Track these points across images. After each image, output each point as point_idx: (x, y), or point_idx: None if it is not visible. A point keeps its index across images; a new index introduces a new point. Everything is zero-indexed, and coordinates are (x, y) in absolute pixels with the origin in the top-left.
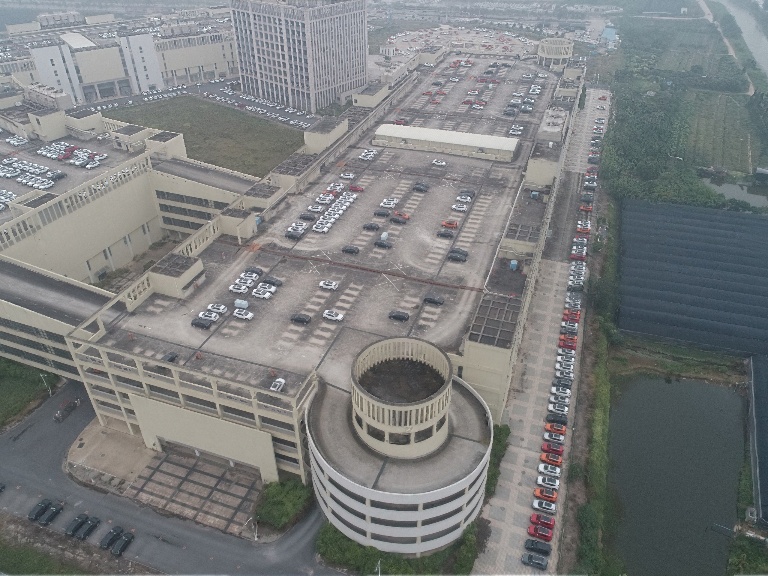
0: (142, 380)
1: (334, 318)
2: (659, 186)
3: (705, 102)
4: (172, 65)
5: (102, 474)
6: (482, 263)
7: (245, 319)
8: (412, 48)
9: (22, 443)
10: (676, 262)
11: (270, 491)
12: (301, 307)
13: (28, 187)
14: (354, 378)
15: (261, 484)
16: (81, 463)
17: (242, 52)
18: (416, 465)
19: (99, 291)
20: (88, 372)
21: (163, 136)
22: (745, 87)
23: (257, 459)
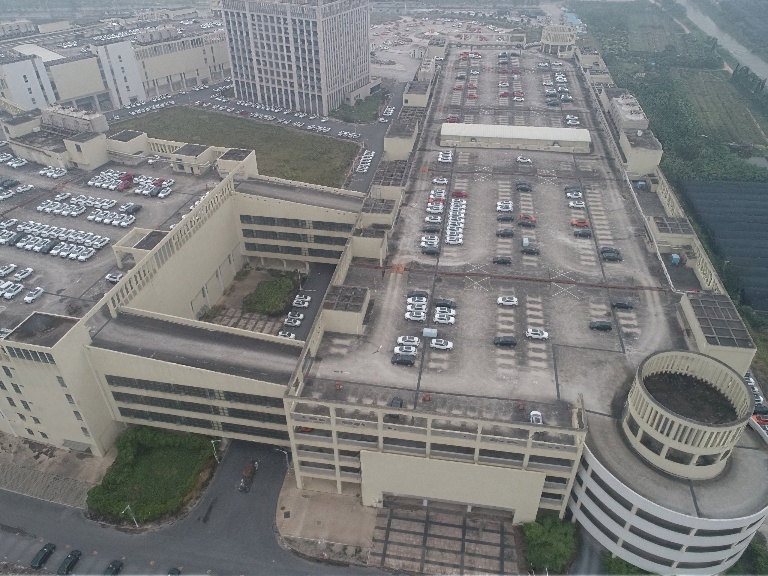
0: (380, 434)
1: (540, 336)
2: (703, 165)
3: (691, 80)
4: (153, 74)
5: (330, 544)
6: (639, 260)
7: (446, 349)
8: (388, 42)
9: (216, 523)
10: (765, 238)
11: (533, 533)
12: (494, 328)
13: (105, 225)
14: (657, 403)
15: (512, 526)
16: (299, 536)
17: (236, 56)
18: (720, 484)
19: (268, 337)
20: (298, 432)
21: (235, 154)
22: (721, 63)
23: (516, 501)
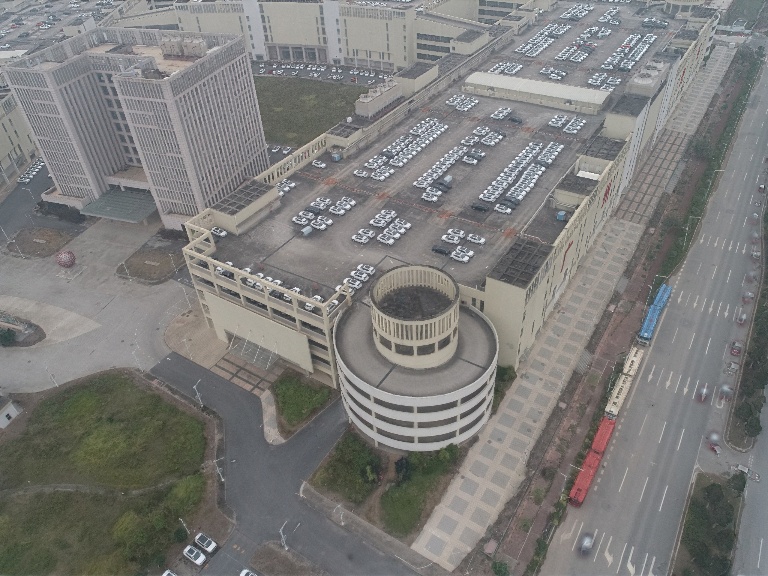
0: None
1: None
2: None
3: None
4: None
5: None
6: None
7: None
8: None
9: None
10: None
11: None
12: None
13: None
14: None
15: None
16: None
17: None
18: None
19: None
20: None
21: (184, 1)
22: None
23: None
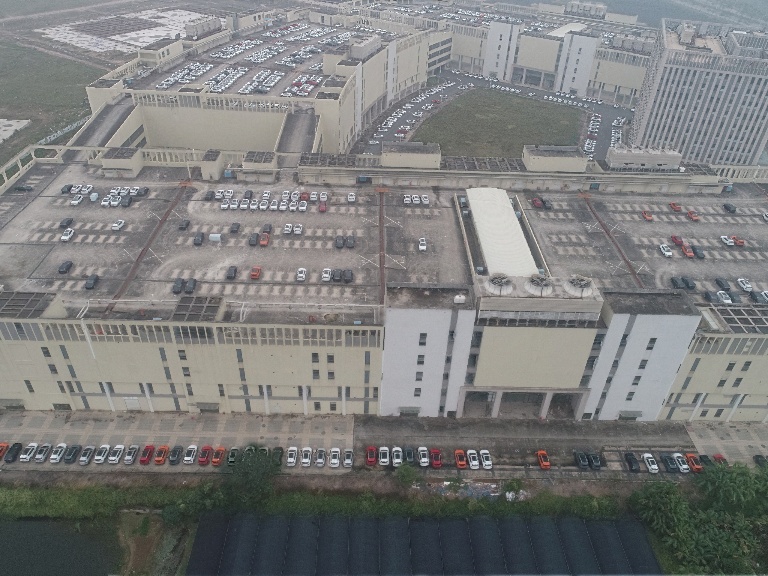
0: None
1: None
2: None
3: None
4: (604, 77)
5: None
6: (172, 305)
7: None
8: None
9: None
10: None
11: None
12: (88, 221)
13: None
14: None
15: None
16: None
17: None
18: None
19: None
20: None
21: (330, 95)
22: None
23: None
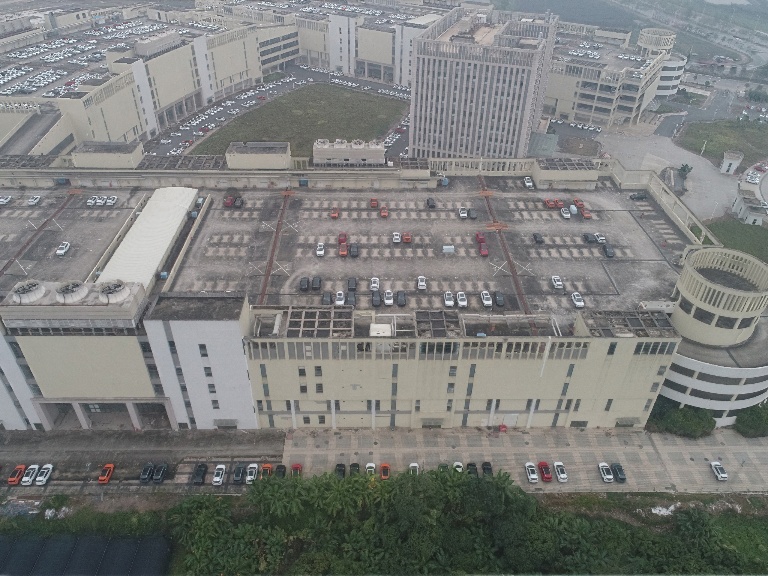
0: None
1: None
2: None
3: None
4: None
5: None
6: None
7: None
8: None
9: None
10: None
11: None
12: None
13: None
14: None
15: None
16: None
17: None
18: None
19: None
20: None
21: (77, 94)
22: None
23: None
